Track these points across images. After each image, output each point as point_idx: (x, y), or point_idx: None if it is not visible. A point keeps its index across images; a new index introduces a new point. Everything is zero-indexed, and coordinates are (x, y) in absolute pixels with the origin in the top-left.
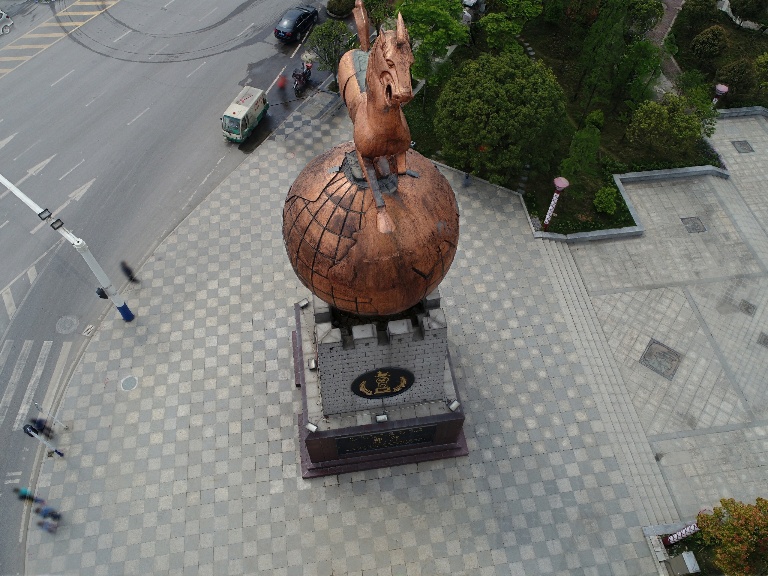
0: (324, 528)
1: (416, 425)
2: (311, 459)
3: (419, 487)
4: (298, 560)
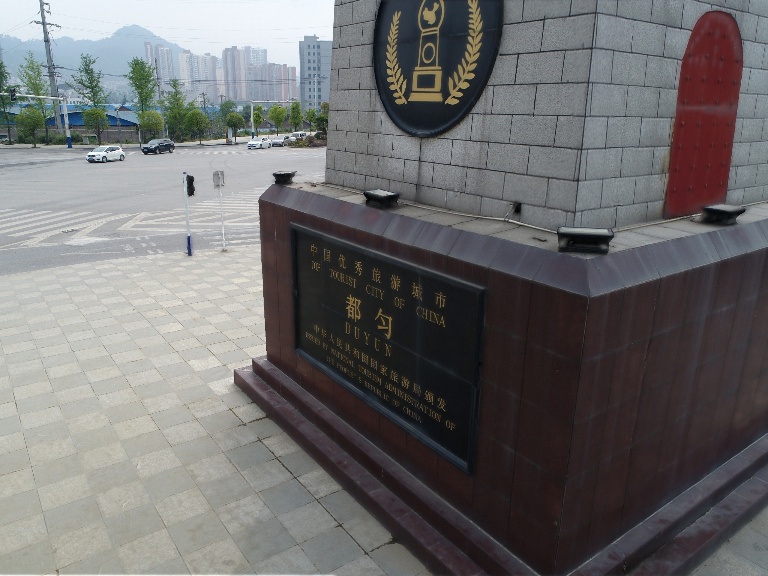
0: (122, 434)
1: (431, 255)
2: (266, 331)
3: (316, 572)
4: (34, 422)
